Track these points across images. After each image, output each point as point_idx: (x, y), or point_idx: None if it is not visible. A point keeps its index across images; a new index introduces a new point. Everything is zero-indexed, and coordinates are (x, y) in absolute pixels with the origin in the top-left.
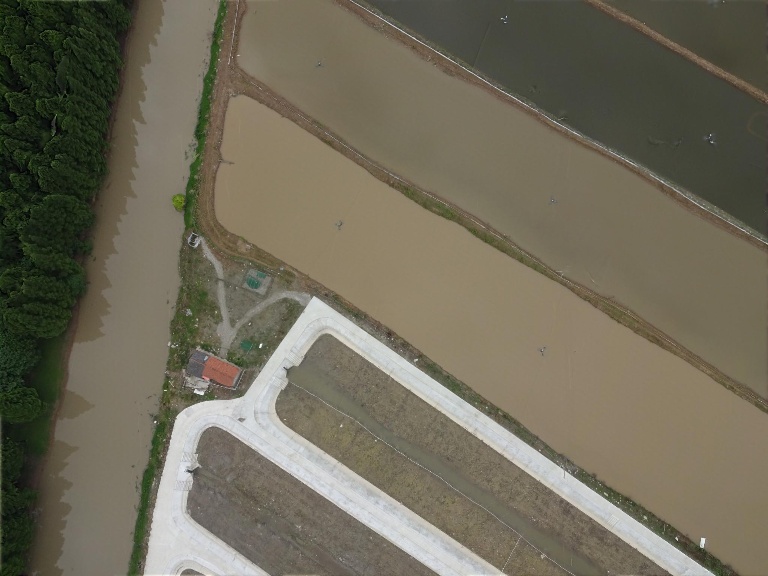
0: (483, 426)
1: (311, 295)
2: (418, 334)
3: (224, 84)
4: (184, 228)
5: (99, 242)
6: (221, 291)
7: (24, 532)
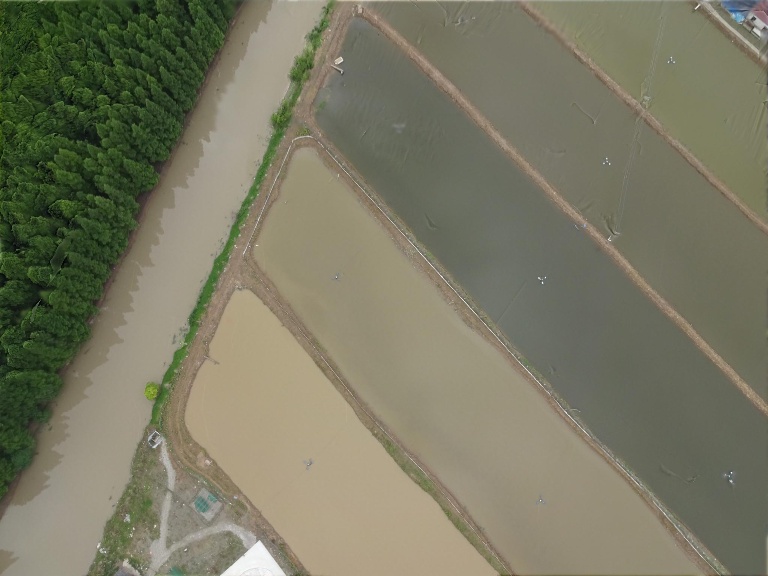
0: None
1: (257, 538)
2: None
3: (233, 274)
4: (150, 420)
5: (61, 409)
6: (167, 504)
7: None
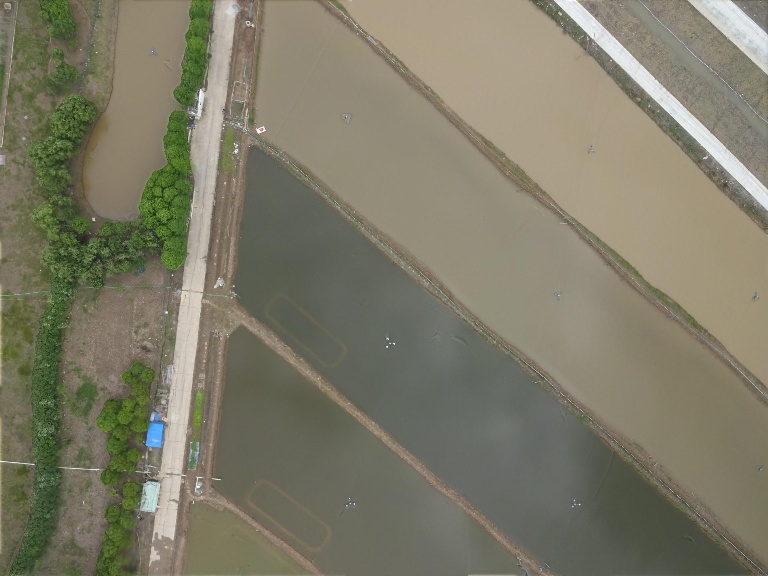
0: (657, 90)
1: None
2: None
3: None
4: None
5: None
6: None
7: None
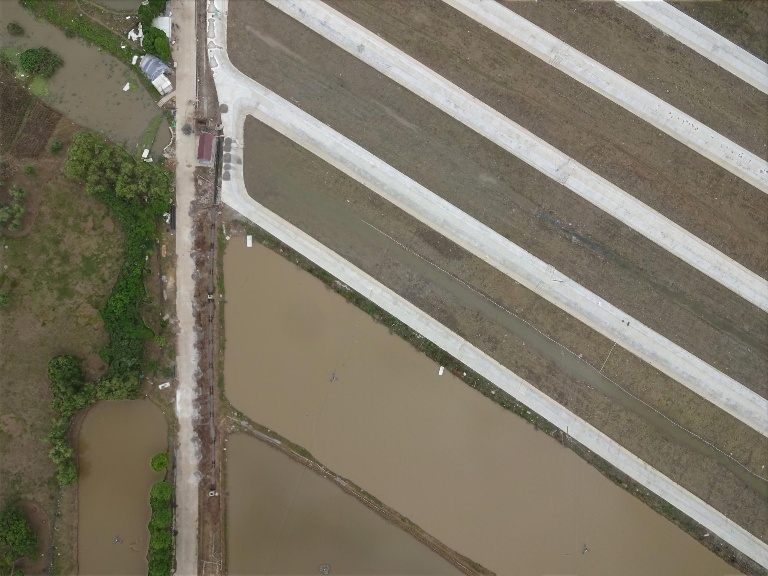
0: (642, 473)
1: None
2: None
3: None
4: None
5: None
6: None
7: None
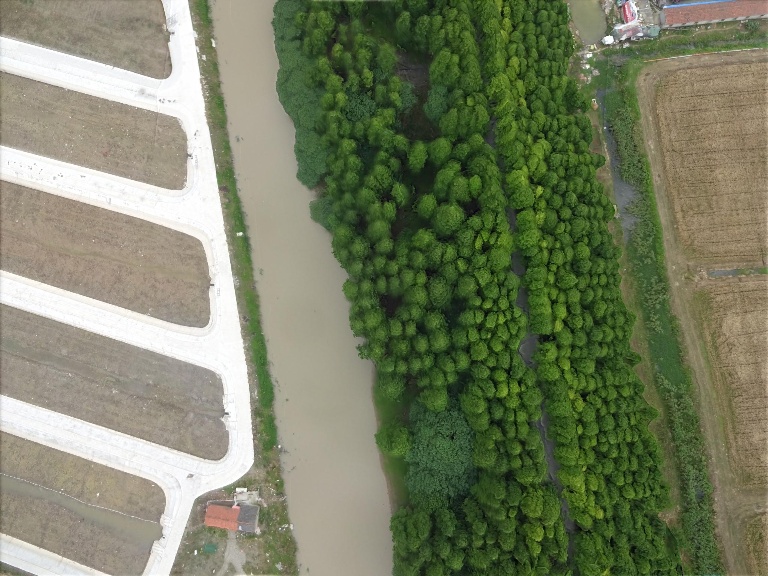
0: None
1: None
2: None
3: None
4: None
5: None
6: None
7: None
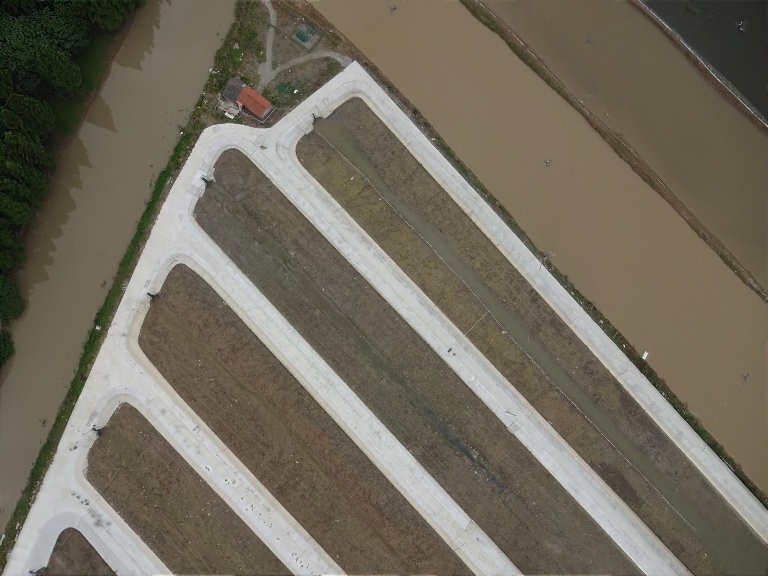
0: (479, 209)
1: (353, 59)
2: (441, 117)
3: None
4: None
5: None
6: (271, 36)
7: (40, 186)
